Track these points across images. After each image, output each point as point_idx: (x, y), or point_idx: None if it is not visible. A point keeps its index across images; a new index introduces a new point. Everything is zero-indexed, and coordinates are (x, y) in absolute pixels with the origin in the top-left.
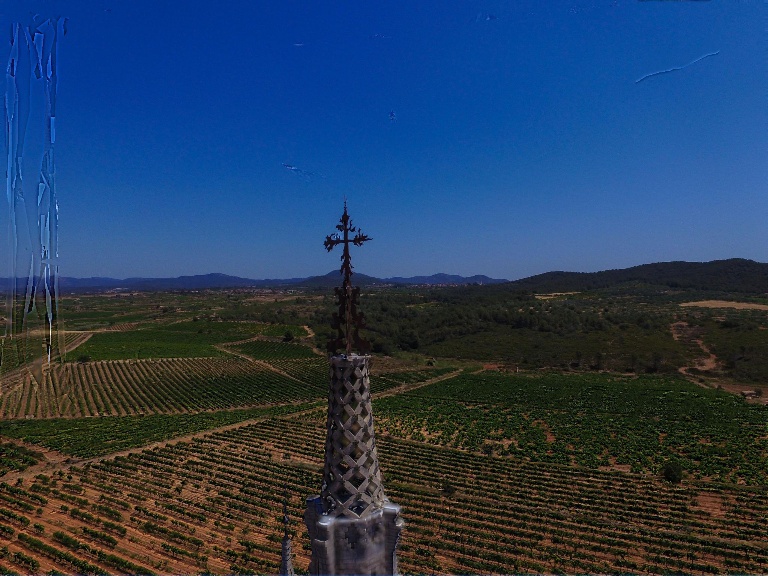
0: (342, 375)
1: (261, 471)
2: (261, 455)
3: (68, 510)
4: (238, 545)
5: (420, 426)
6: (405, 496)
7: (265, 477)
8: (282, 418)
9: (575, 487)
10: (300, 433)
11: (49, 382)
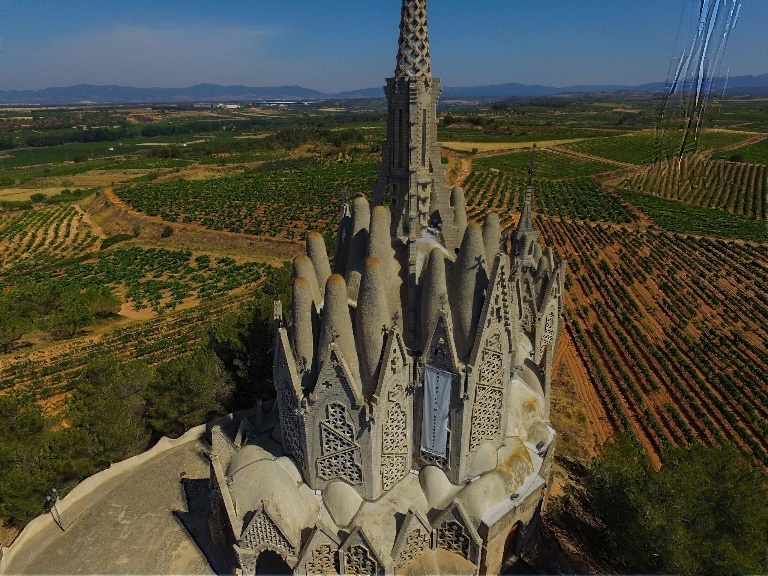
0: None
1: None
2: None
3: (622, 253)
4: (729, 334)
5: None
6: None
7: None
8: None
9: None
10: None
11: (677, 166)
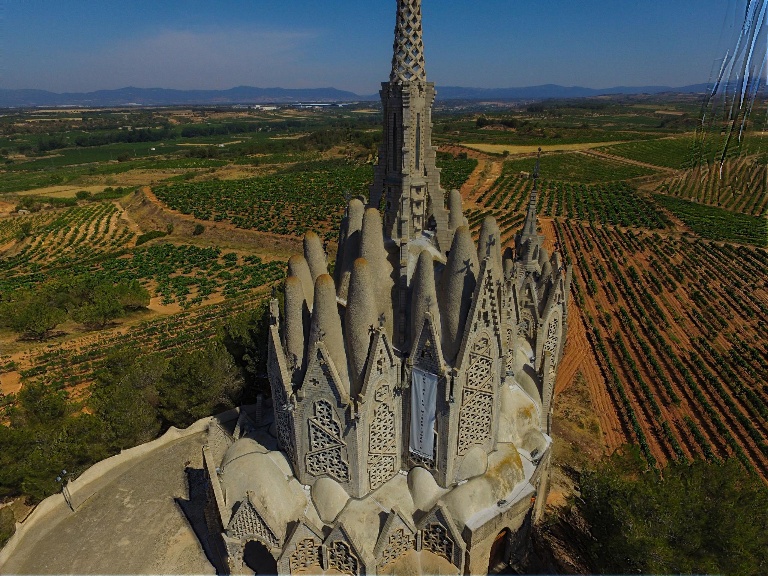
0: None
1: None
2: None
3: (652, 260)
4: (762, 347)
5: None
6: None
7: None
8: None
9: None
10: None
11: (718, 171)
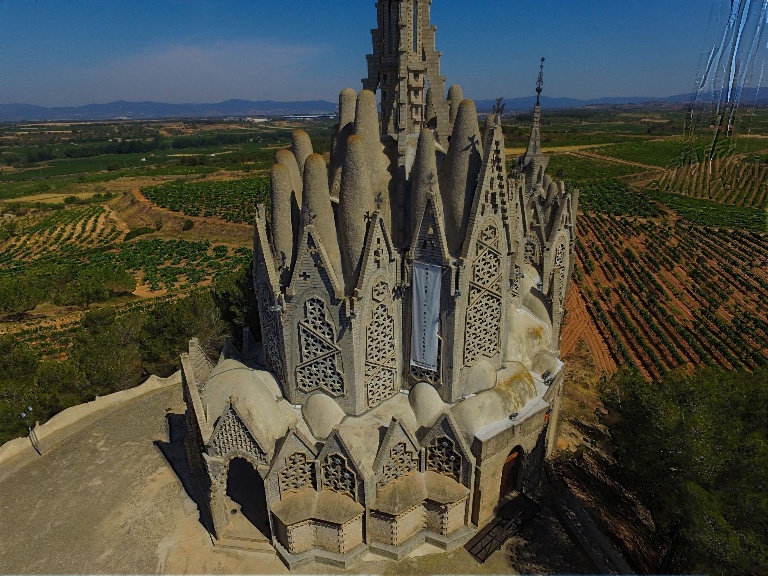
0: None
1: None
2: None
3: (648, 243)
4: (765, 318)
5: None
6: None
7: None
8: None
9: None
10: None
11: (708, 164)
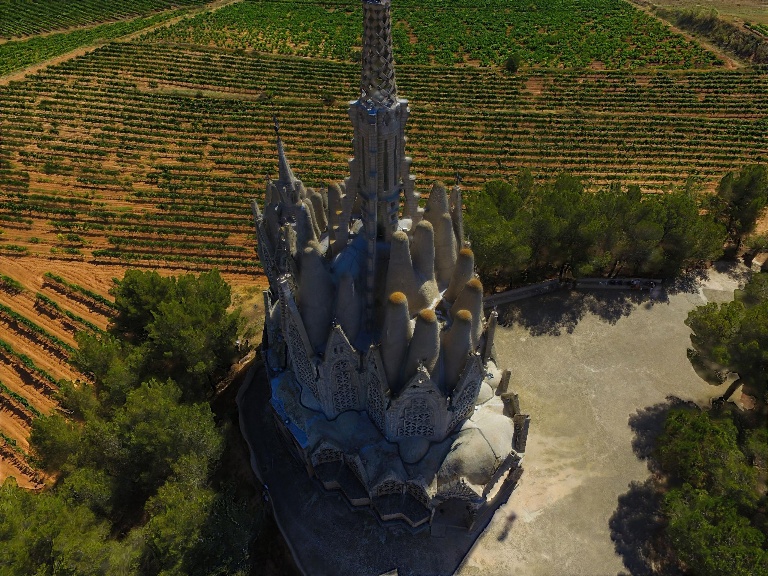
0: (378, 16)
1: (133, 103)
2: (123, 86)
3: None
4: (152, 170)
5: (284, 38)
6: (291, 109)
7: (142, 108)
8: (123, 41)
9: (435, 84)
10: (155, 57)
11: None
